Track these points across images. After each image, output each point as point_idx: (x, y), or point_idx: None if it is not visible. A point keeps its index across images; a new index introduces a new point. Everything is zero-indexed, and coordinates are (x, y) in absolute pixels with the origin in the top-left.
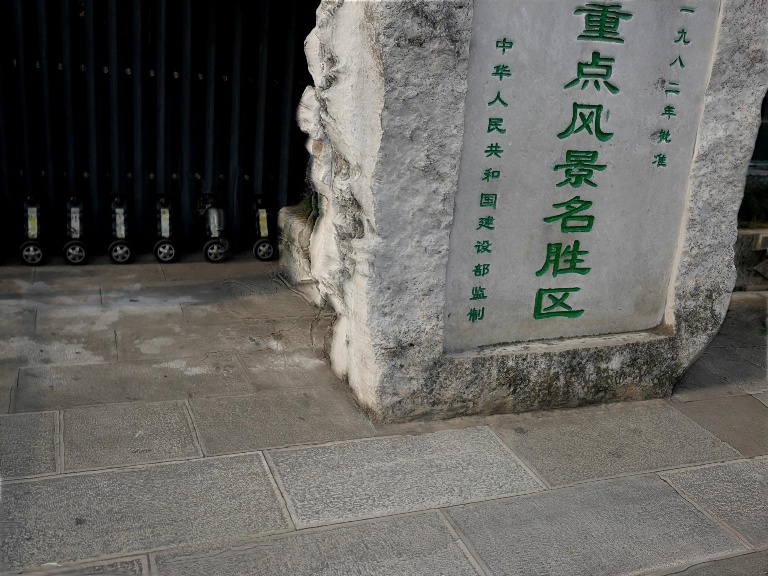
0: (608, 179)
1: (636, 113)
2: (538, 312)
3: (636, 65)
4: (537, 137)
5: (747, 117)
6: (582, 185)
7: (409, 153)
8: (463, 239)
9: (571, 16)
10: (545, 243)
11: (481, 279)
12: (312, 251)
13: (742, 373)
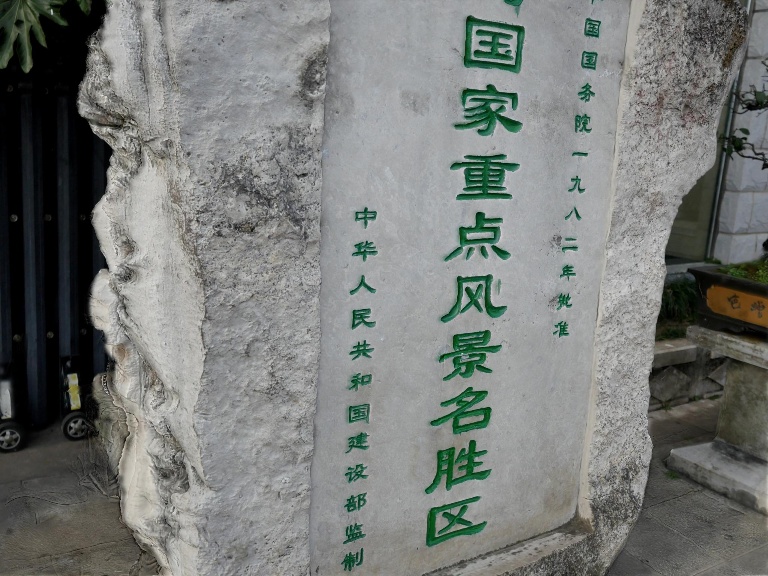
0: (504, 361)
1: (531, 279)
2: (431, 537)
3: (528, 223)
4: (416, 325)
5: (651, 268)
6: (474, 373)
7: (246, 373)
8: (329, 469)
9: (447, 172)
10: (434, 451)
11: (356, 514)
12: (121, 486)
13: (663, 549)
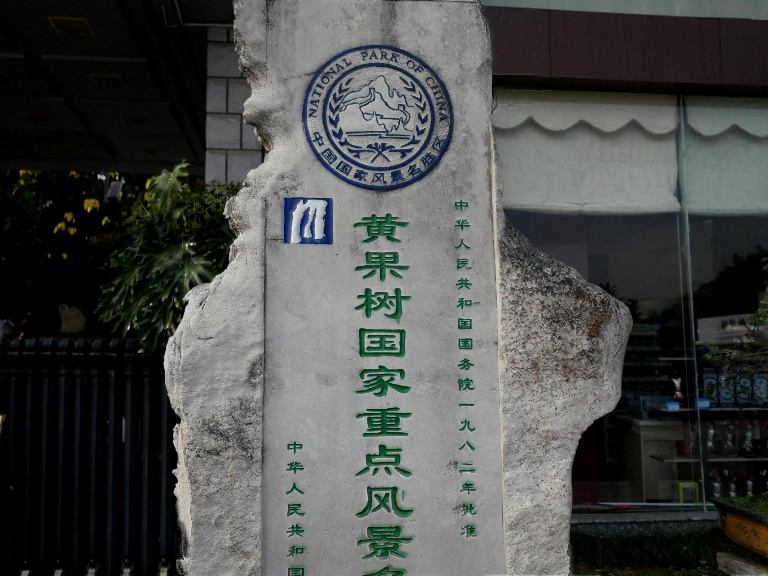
0: (416, 551)
1: (432, 491)
2: None
3: (424, 452)
4: (336, 517)
5: (553, 488)
6: (389, 557)
7: (216, 537)
8: None
9: (354, 419)
10: None
11: None
12: None
13: None
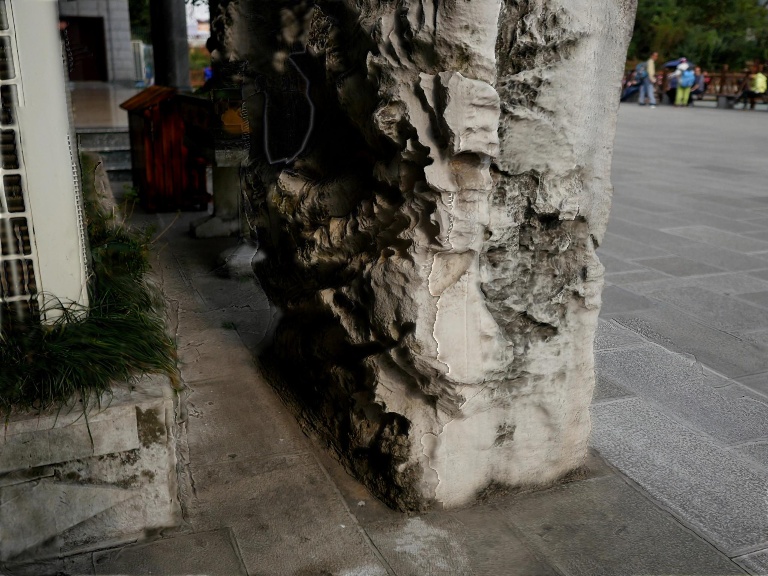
0: None
1: None
2: None
3: None
4: None
5: None
6: None
7: None
8: None
9: None
10: None
11: None
12: (451, 352)
13: None
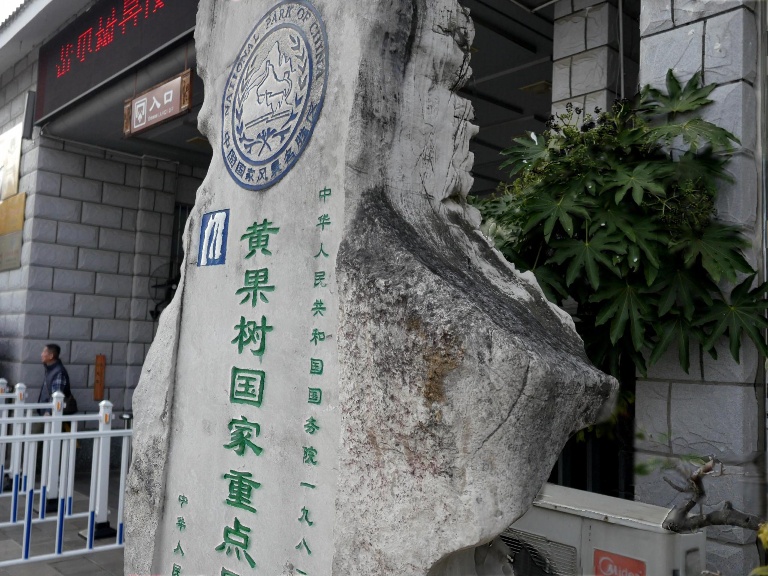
0: None
1: None
2: None
3: (267, 539)
4: None
5: None
6: None
7: None
8: None
9: (223, 479)
10: None
11: None
12: None
13: None
